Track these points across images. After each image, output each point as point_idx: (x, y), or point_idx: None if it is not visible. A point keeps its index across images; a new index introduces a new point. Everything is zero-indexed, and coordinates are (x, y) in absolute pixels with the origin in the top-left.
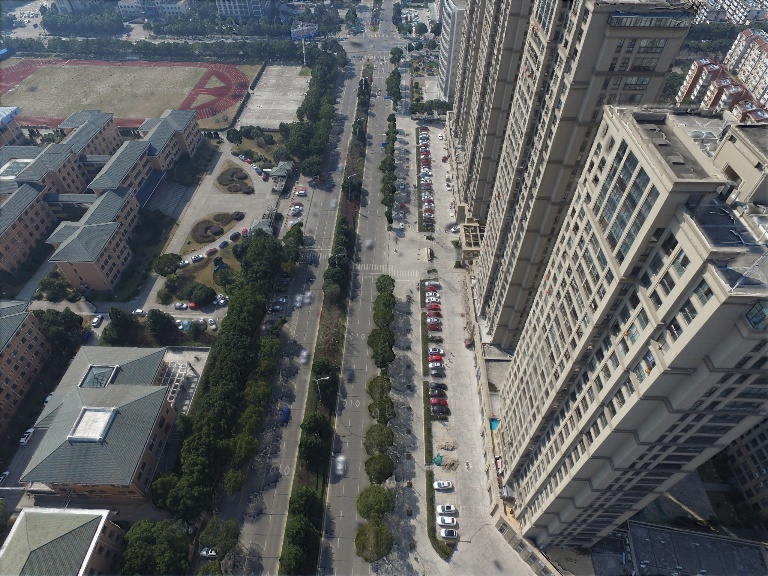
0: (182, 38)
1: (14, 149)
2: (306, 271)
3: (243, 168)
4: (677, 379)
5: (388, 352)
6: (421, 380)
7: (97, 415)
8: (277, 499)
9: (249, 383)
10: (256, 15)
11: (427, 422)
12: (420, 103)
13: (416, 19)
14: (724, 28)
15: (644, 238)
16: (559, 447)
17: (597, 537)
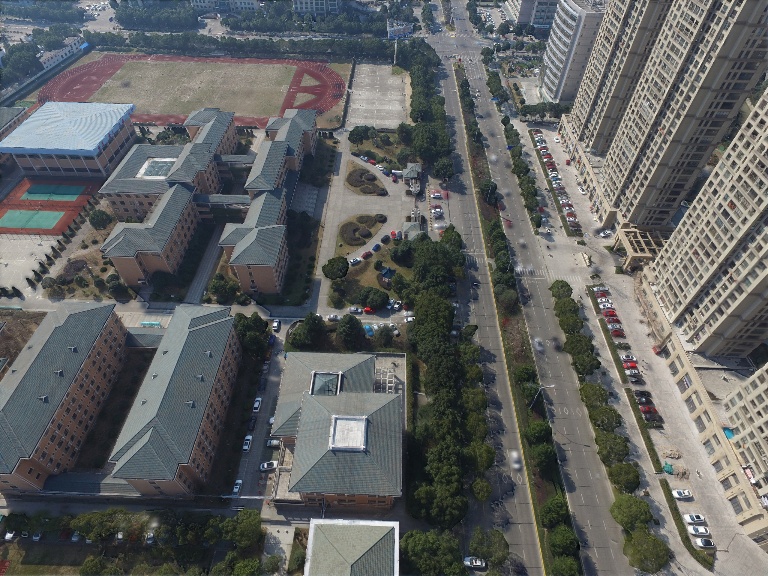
0: (261, 34)
1: (150, 148)
2: (468, 275)
3: (369, 169)
4: None
5: (596, 359)
6: (621, 387)
7: (350, 424)
8: (520, 508)
9: (464, 390)
10: (332, 12)
11: (644, 430)
12: (532, 105)
13: (490, 19)
14: None
15: None
16: None
17: None
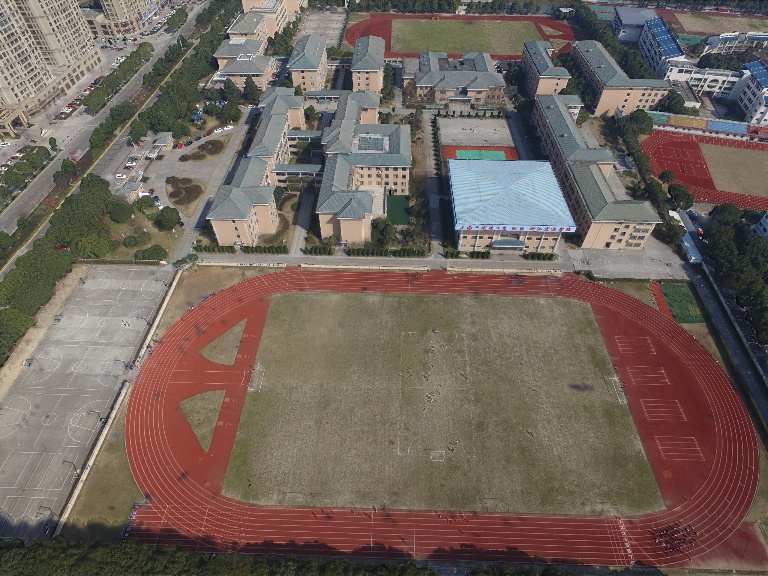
0: None
1: None
2: None
3: (173, 205)
4: None
5: None
6: None
7: None
8: None
9: None
10: None
11: None
12: None
13: None
14: None
15: None
16: None
17: None
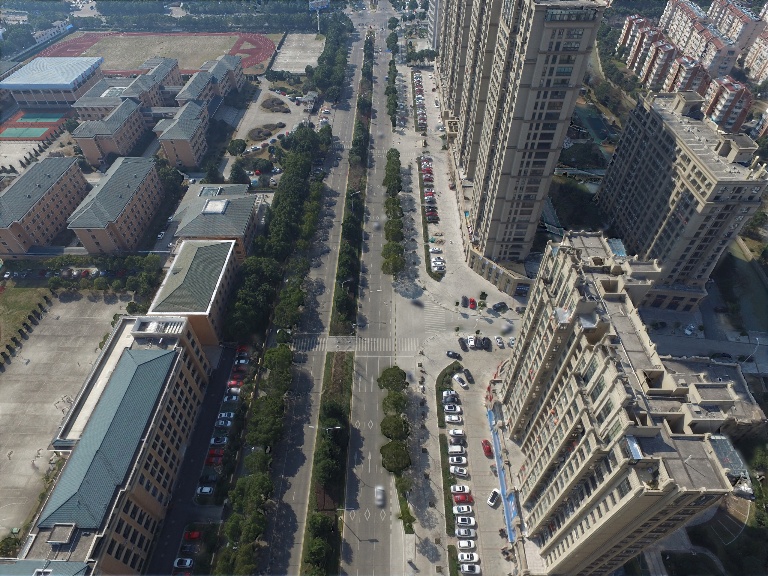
0: (214, 16)
1: (111, 80)
2: (335, 154)
3: (280, 98)
4: (531, 69)
5: (397, 184)
6: (420, 206)
7: (217, 203)
8: (330, 260)
9: (306, 202)
10: None
11: (424, 224)
12: None
13: None
14: (660, 0)
15: (514, 6)
16: (495, 165)
17: (525, 243)
